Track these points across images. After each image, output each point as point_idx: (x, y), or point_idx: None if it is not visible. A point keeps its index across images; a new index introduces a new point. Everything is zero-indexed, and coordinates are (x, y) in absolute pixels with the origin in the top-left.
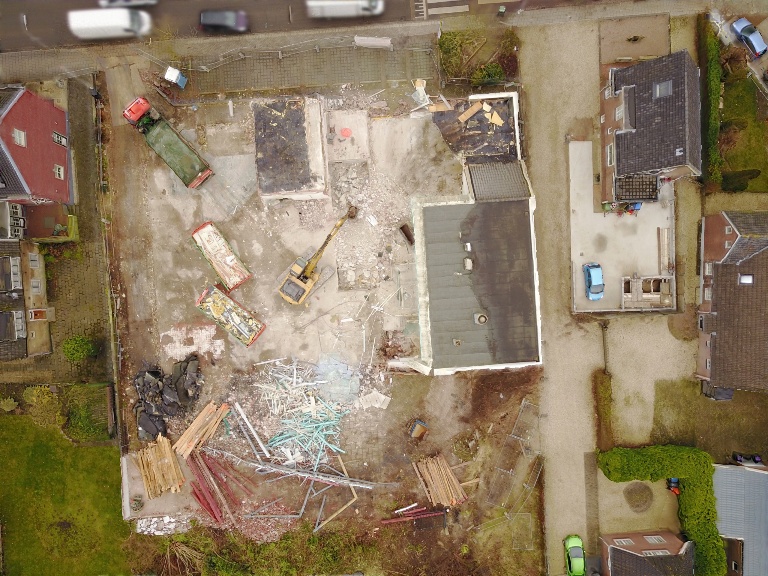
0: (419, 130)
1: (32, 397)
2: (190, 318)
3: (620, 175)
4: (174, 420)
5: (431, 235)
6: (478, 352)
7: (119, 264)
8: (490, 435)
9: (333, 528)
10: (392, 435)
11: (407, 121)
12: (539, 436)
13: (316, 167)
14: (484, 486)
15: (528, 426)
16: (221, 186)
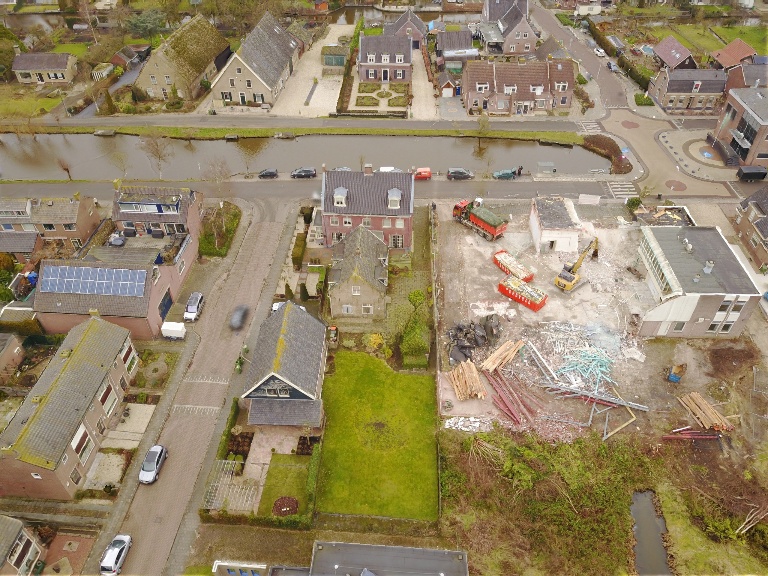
0: (625, 234)
1: (370, 337)
2: (491, 297)
3: (766, 238)
4: (479, 353)
5: (659, 238)
6: (713, 287)
7: (441, 274)
8: (736, 388)
9: (619, 440)
10: (653, 379)
11: (616, 230)
12: None
13: (575, 220)
14: (746, 426)
15: (766, 384)
16: (507, 244)
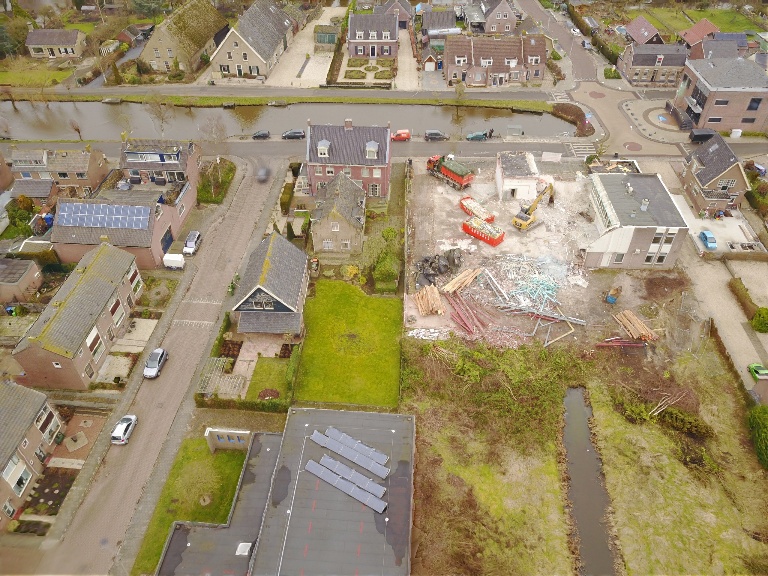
0: (582, 186)
1: (347, 268)
2: (456, 236)
3: (704, 186)
4: (442, 280)
5: (605, 183)
6: (647, 221)
7: (413, 217)
8: None
9: (558, 347)
10: (593, 301)
11: (574, 183)
12: (702, 311)
13: (534, 171)
14: (670, 337)
15: (691, 306)
16: (474, 193)
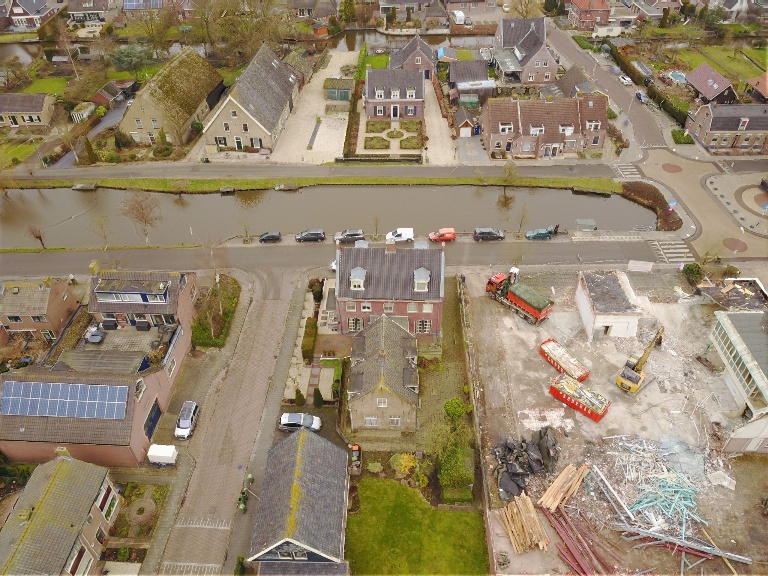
0: (687, 310)
1: (400, 459)
2: (541, 402)
3: None
4: (534, 482)
5: (740, 329)
6: None
7: (478, 369)
8: None
9: None
10: (750, 515)
11: (676, 305)
12: None
13: (634, 301)
14: None
15: None
16: (553, 327)
